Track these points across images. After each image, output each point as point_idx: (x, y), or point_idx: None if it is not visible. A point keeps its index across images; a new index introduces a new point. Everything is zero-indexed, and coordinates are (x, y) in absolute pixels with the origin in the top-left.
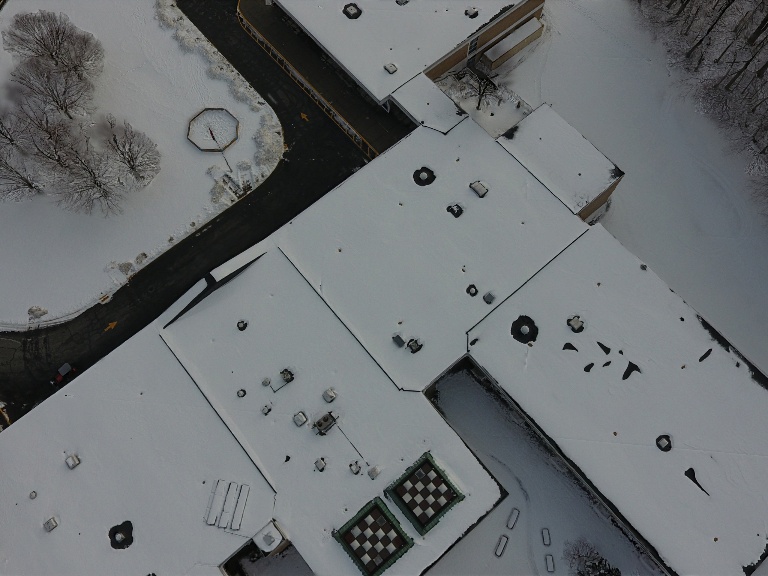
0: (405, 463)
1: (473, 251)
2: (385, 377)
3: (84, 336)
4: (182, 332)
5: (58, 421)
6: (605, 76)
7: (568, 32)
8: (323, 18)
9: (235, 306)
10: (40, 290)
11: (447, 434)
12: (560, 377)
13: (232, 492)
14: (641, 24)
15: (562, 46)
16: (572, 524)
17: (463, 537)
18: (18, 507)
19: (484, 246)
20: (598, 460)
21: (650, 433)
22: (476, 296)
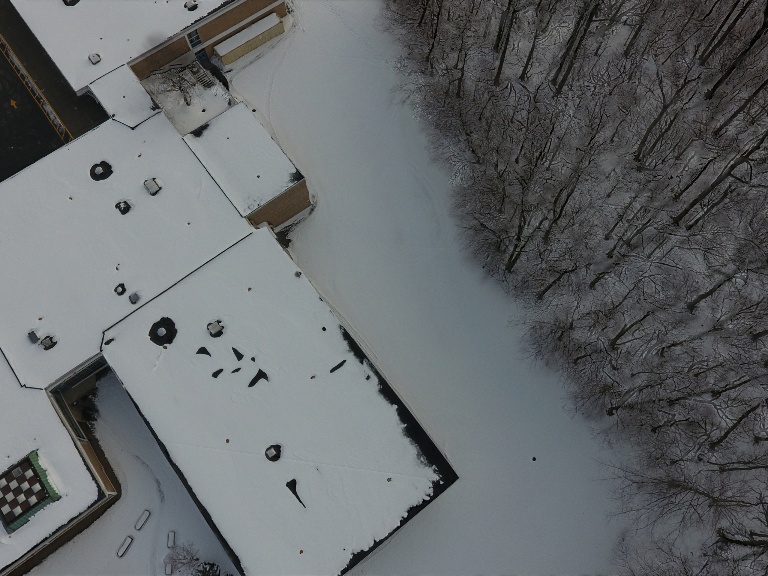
0: (10, 460)
1: (131, 249)
2: (10, 373)
3: None
4: None
5: None
6: (341, 76)
7: (313, 29)
8: (40, 3)
9: None
10: None
11: (59, 433)
12: (186, 381)
13: None
14: (381, 25)
15: (303, 43)
16: (198, 528)
17: (49, 537)
18: None
19: (143, 245)
20: (203, 467)
21: (262, 442)
22: (123, 295)
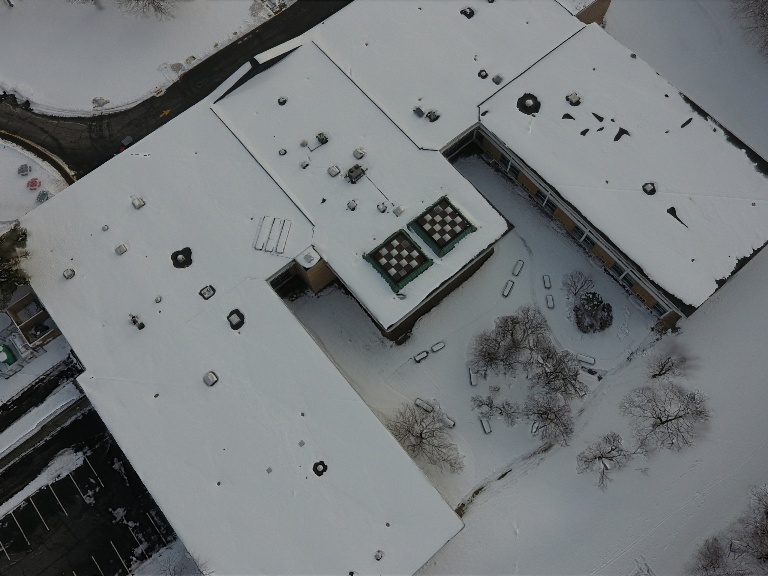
0: (425, 204)
1: (484, 44)
2: (407, 139)
3: (142, 121)
4: (230, 106)
5: (125, 173)
6: None
7: None
8: None
9: (276, 87)
10: (102, 84)
11: (461, 182)
12: (559, 139)
13: (276, 225)
14: None
15: None
16: None
17: (475, 258)
18: (93, 237)
19: (493, 40)
20: (592, 201)
21: (637, 181)
22: (486, 78)
